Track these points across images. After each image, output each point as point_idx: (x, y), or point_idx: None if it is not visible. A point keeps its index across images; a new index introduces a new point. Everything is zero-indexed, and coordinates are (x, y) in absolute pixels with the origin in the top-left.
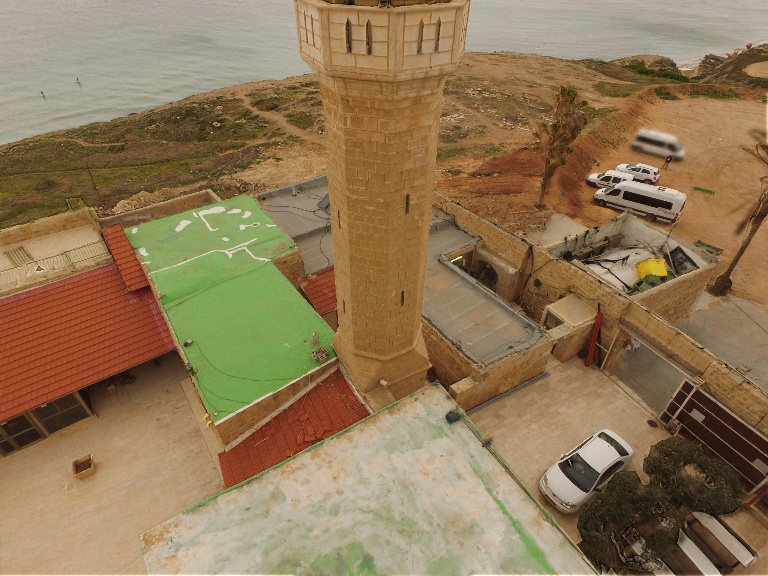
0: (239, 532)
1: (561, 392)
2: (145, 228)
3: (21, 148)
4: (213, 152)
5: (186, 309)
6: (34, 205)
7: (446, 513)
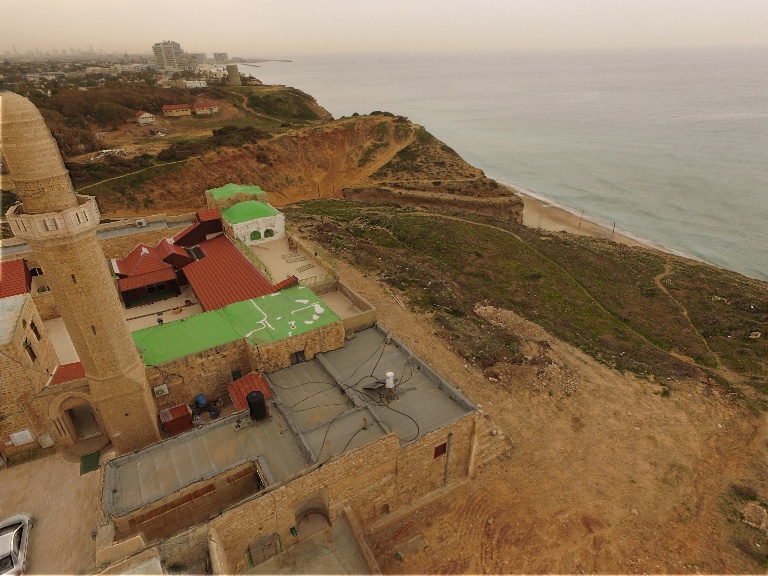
0: None
1: (84, 570)
2: (303, 290)
3: (638, 256)
4: (672, 346)
5: (213, 315)
6: (486, 277)
7: None
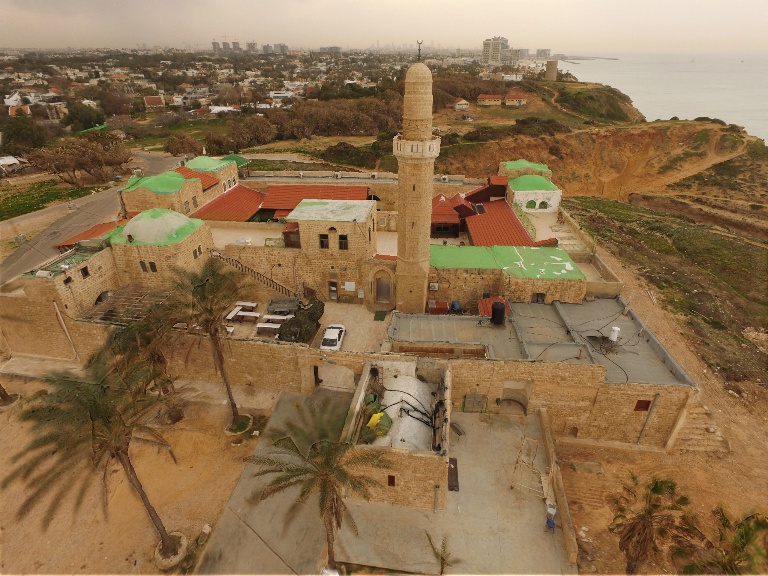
0: (365, 204)
1: None
2: (560, 251)
3: None
4: None
5: (482, 249)
6: None
7: (341, 215)
